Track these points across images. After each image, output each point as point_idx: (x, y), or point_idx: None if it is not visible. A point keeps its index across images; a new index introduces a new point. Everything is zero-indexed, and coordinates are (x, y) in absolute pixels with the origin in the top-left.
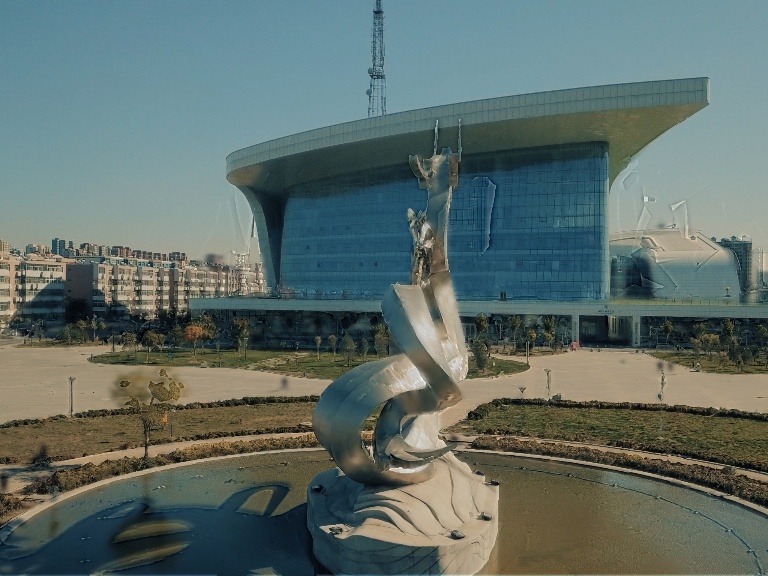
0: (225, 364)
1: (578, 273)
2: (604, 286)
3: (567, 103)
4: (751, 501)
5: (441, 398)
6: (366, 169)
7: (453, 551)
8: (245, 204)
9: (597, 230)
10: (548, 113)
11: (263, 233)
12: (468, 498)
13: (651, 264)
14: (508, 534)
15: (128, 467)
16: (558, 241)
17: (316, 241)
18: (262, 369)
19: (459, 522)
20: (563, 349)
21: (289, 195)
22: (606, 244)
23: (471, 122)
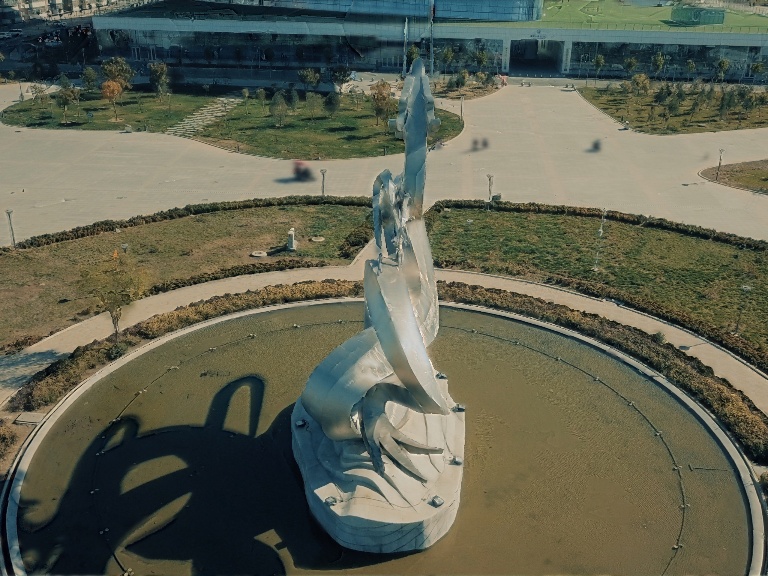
0: (150, 125)
1: None
2: (537, 2)
3: None
4: (676, 384)
5: None
6: None
7: (435, 520)
8: None
9: None
10: None
11: None
12: (440, 437)
13: None
14: (459, 391)
15: (102, 357)
16: None
17: None
18: (191, 135)
19: (435, 473)
20: (494, 86)
21: None
22: None
23: None
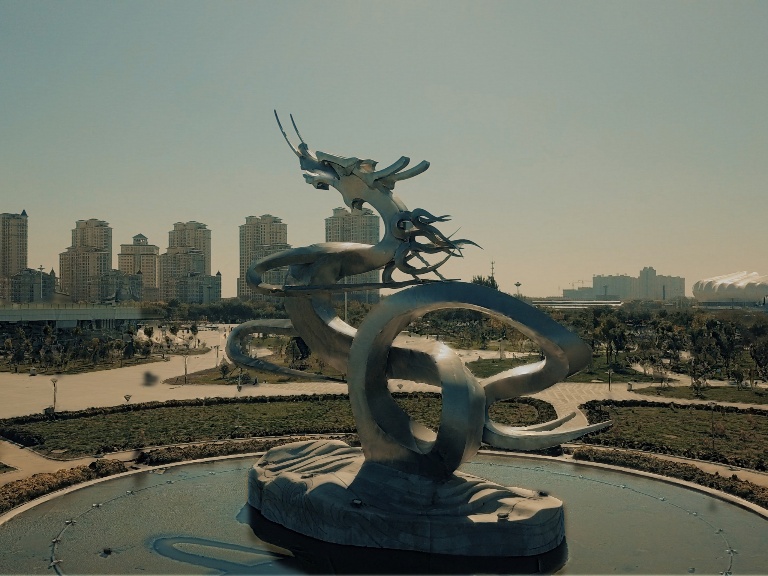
0: None
1: None
2: None
3: None
4: None
5: None
6: None
7: None
8: None
9: None
10: None
11: None
12: None
13: None
14: None
15: None
16: None
17: None
18: None
19: None
20: None
21: None
22: None
23: None
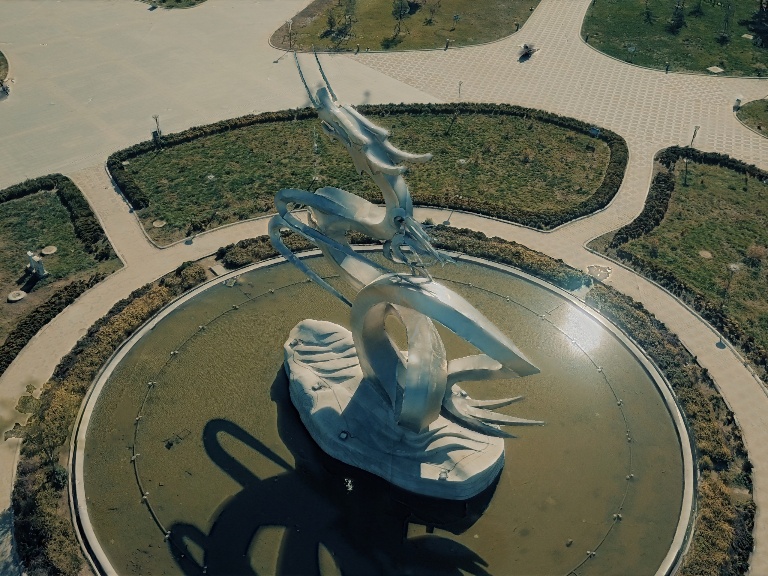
0: None
1: None
2: None
3: None
4: (477, 256)
5: None
6: None
7: None
8: None
9: None
10: None
11: None
12: None
13: None
14: None
15: (53, 492)
16: None
17: None
18: None
19: None
20: None
21: None
22: None
23: None
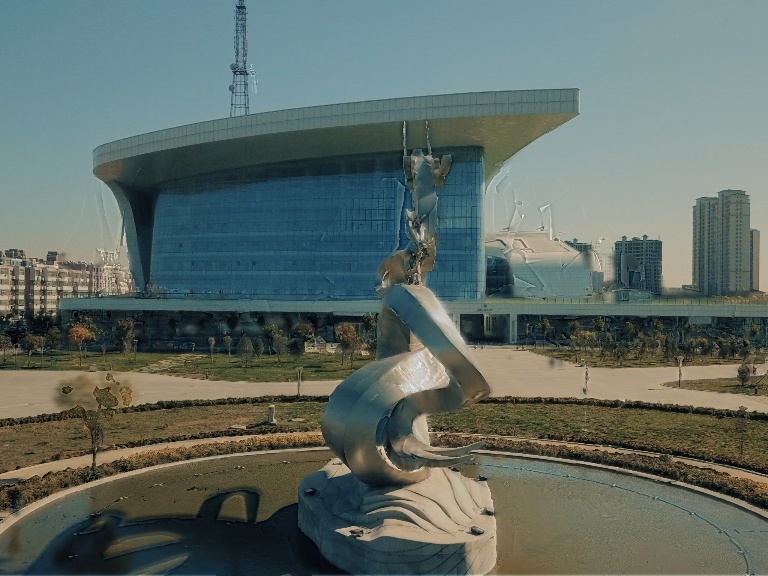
0: (115, 367)
1: (456, 273)
2: (481, 286)
3: (448, 108)
4: (697, 485)
5: (468, 397)
6: (243, 166)
7: (477, 547)
8: (112, 200)
9: (474, 231)
10: (430, 117)
11: (131, 230)
12: (466, 494)
13: (521, 265)
14: None
15: (76, 478)
16: (437, 242)
17: (190, 239)
18: (158, 372)
19: (467, 518)
20: None
21: (160, 191)
22: (482, 245)
23: (355, 123)
